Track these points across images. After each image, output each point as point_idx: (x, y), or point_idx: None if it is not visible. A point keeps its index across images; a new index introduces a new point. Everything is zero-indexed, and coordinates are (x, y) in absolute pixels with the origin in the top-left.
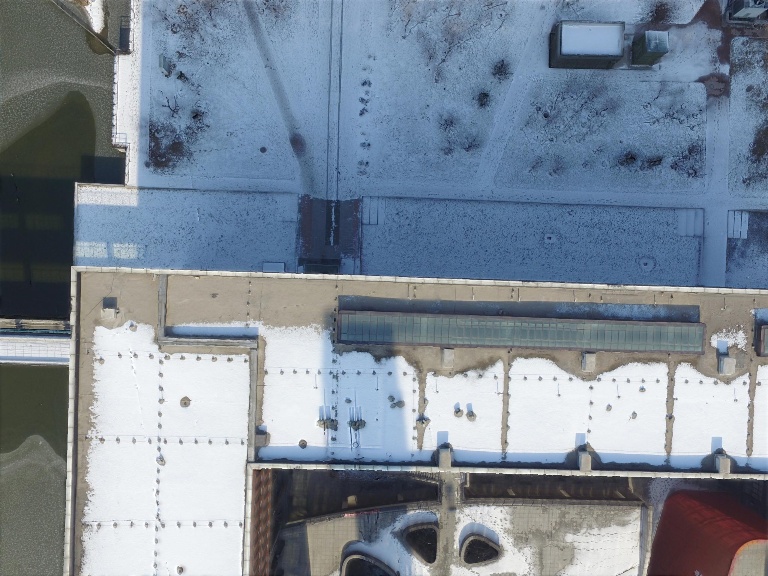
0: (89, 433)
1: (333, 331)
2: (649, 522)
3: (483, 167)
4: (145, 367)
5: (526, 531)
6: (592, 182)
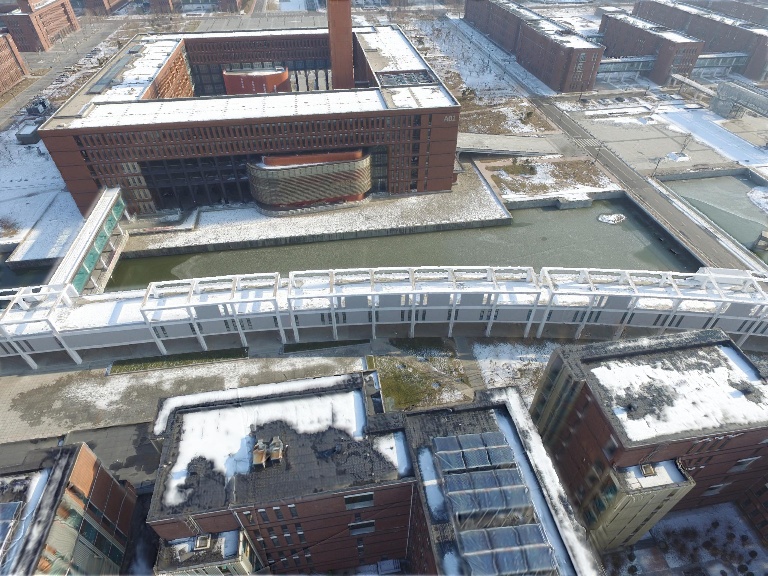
0: None
1: None
2: None
3: None
4: None
5: None
6: None
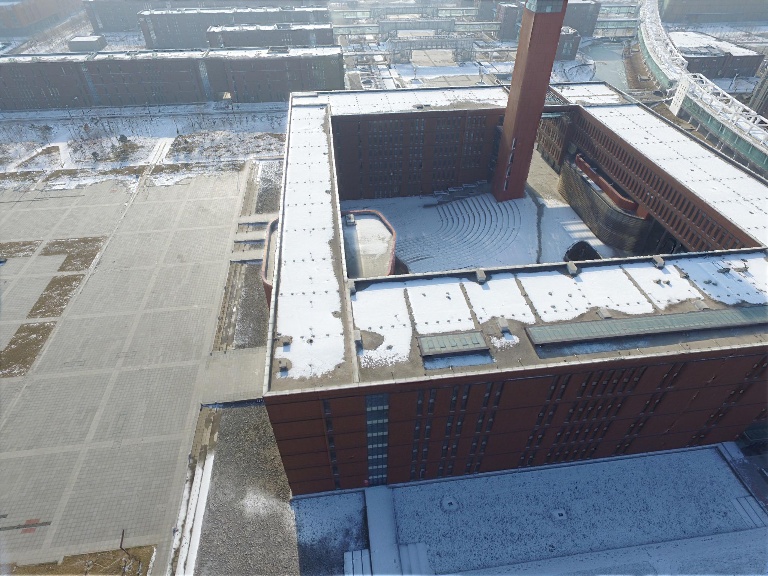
0: None
1: None
2: None
3: None
4: None
5: None
6: None
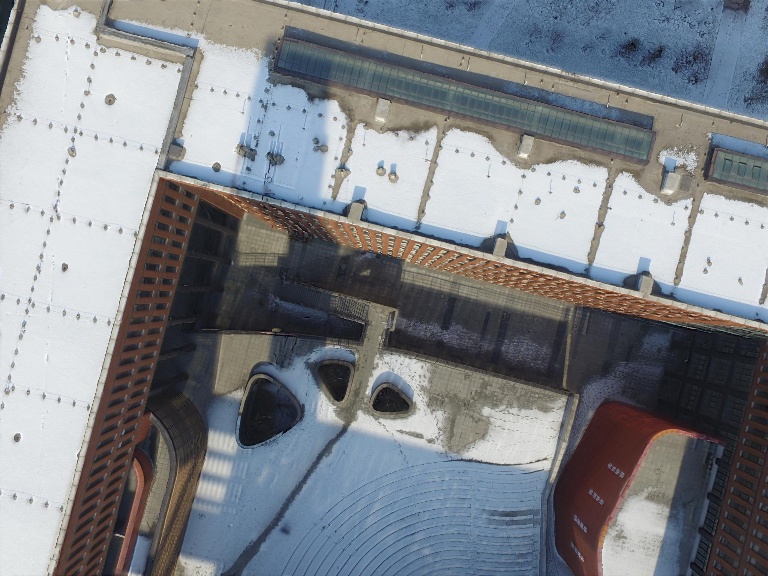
0: (9, 108)
1: (272, 59)
2: (572, 411)
3: (481, 30)
4: (79, 55)
5: (443, 394)
6: (588, 68)
